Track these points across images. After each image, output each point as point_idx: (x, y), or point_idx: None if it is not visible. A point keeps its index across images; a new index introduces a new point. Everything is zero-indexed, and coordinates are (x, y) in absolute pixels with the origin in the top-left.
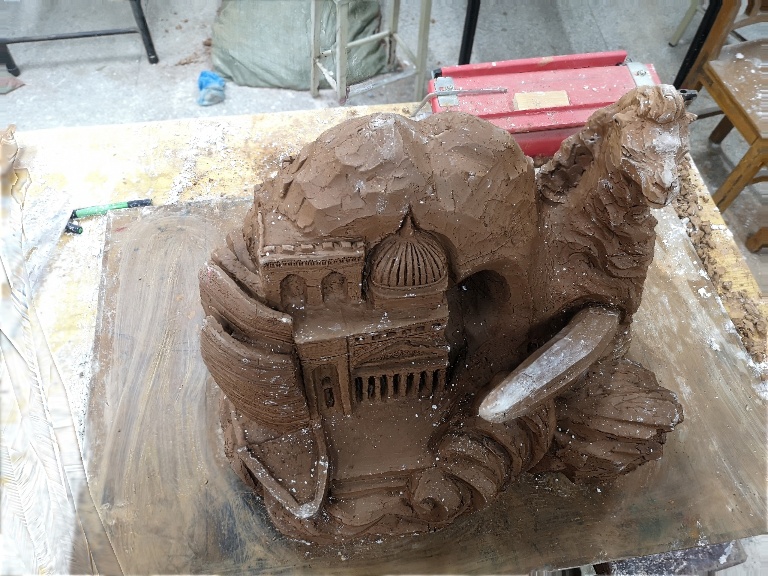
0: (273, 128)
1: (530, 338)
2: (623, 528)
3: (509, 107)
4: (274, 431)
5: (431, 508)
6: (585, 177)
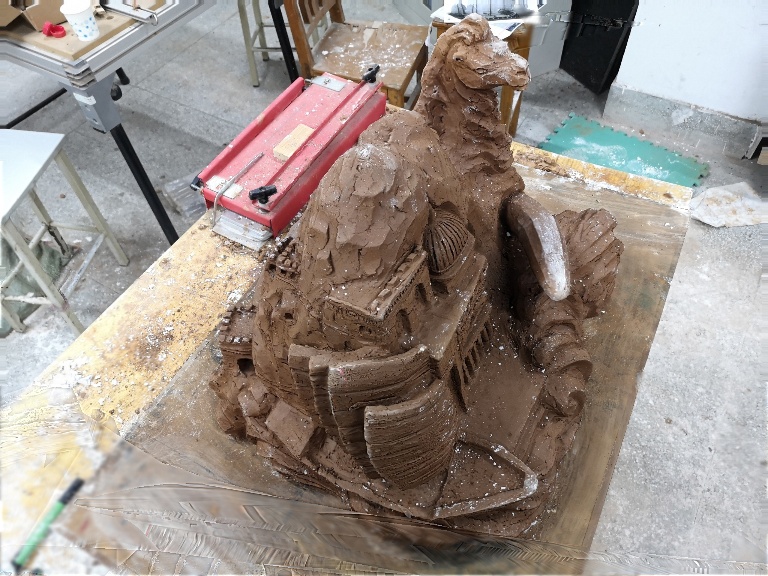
0: (114, 328)
1: (501, 251)
2: (636, 316)
3: (277, 162)
4: (437, 477)
5: (575, 401)
6: (447, 120)
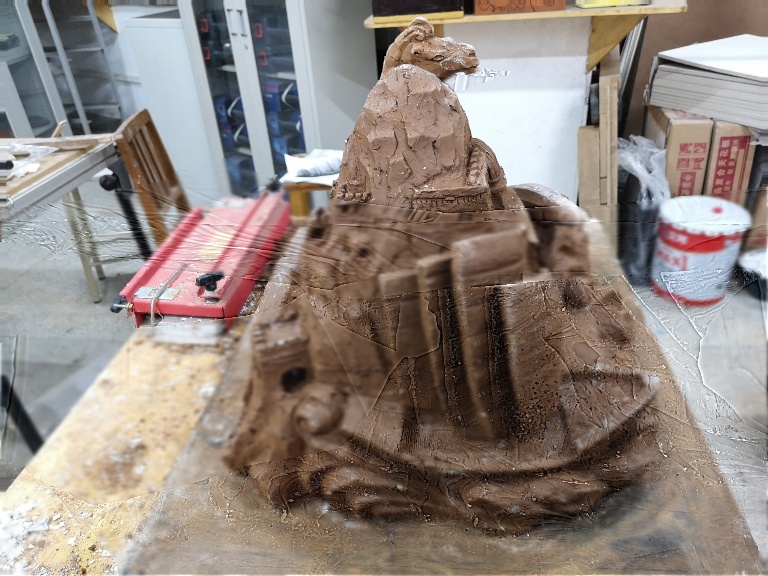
0: None
1: None
2: None
3: None
4: None
5: None
6: None
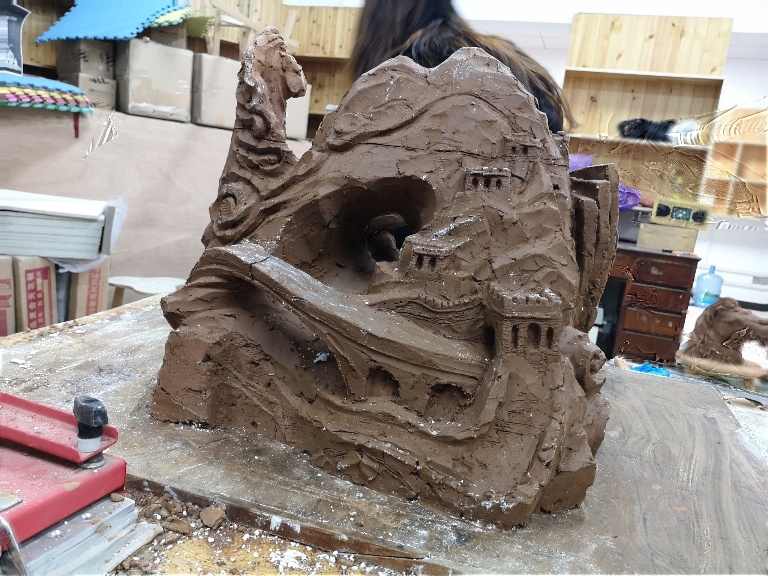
0: None
1: None
2: None
3: None
4: None
5: None
6: None
